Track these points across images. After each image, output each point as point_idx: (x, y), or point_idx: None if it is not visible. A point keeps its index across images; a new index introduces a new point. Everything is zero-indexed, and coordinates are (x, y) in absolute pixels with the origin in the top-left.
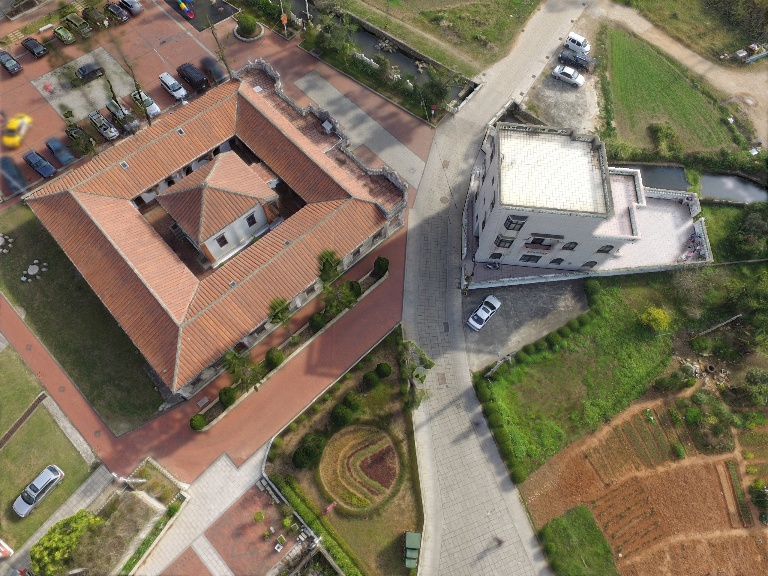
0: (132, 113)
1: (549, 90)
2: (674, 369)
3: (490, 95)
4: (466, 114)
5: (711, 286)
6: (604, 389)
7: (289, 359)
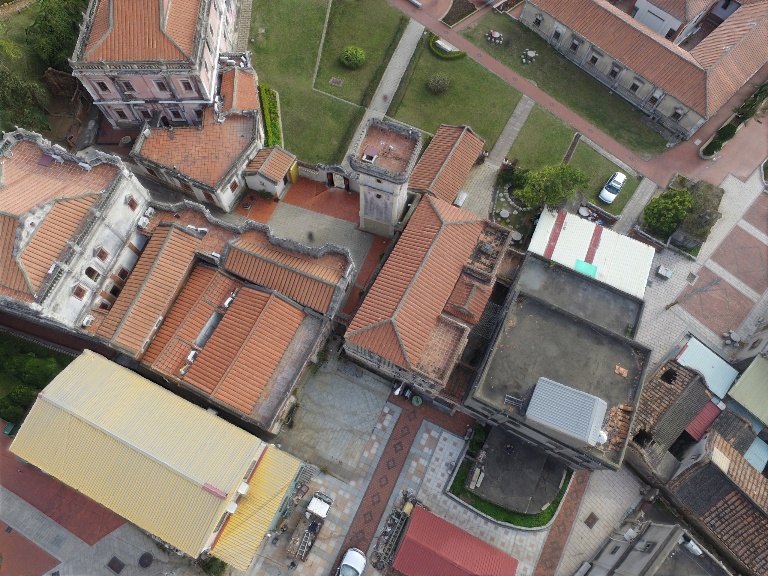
0: None
1: None
2: None
3: None
4: None
5: None
6: None
7: None
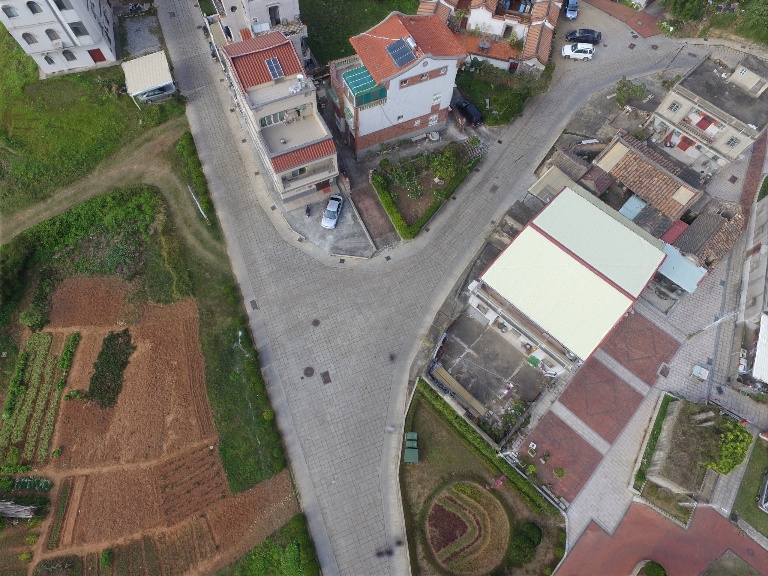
0: None
1: None
2: None
3: None
4: None
5: None
6: None
7: None
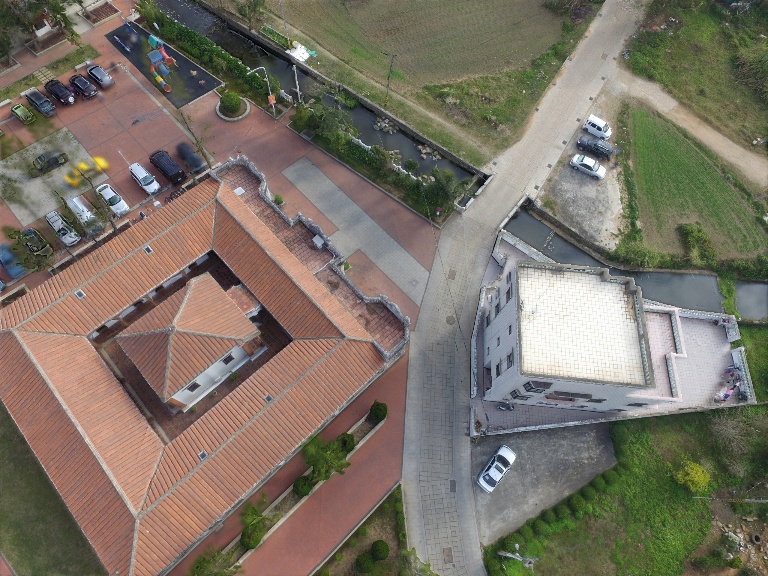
0: (96, 214)
1: (567, 183)
2: (715, 539)
3: (501, 189)
4: (475, 212)
5: (754, 433)
6: (636, 568)
7: (269, 534)
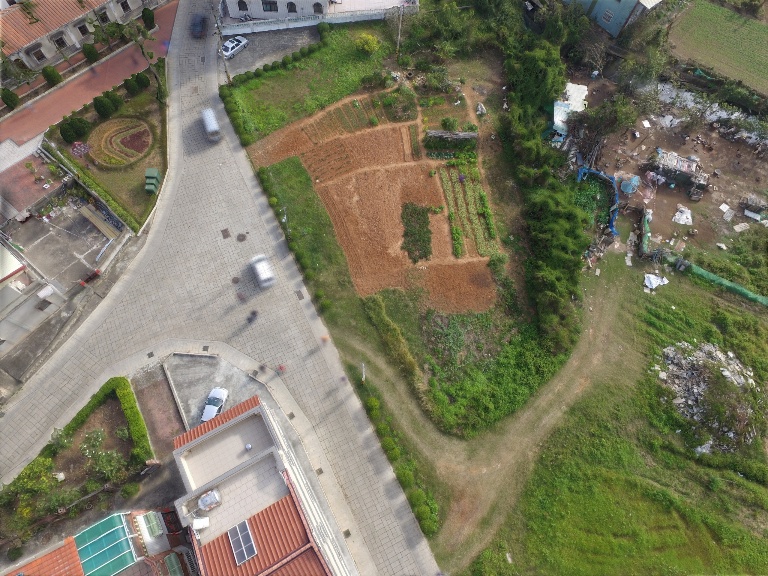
0: None
1: None
2: None
3: None
4: None
5: (417, 23)
6: (323, 90)
7: (68, 80)
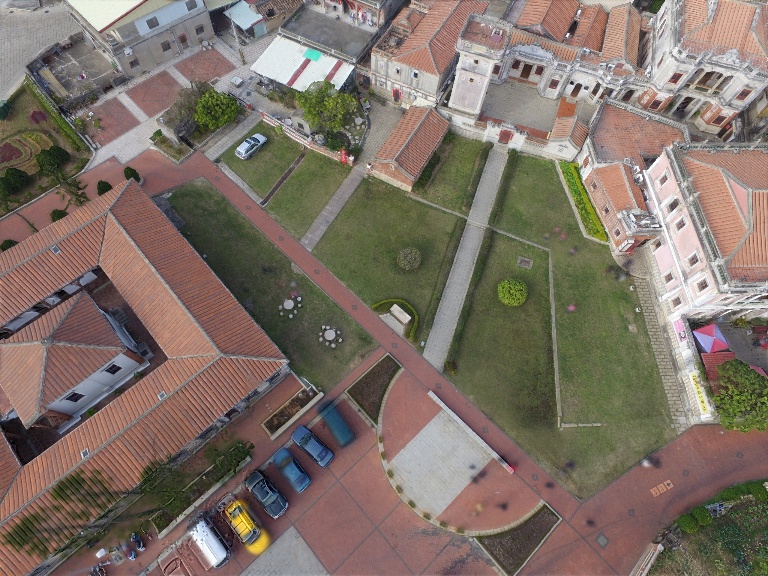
0: None
1: None
2: None
3: None
4: None
5: None
6: None
7: None
